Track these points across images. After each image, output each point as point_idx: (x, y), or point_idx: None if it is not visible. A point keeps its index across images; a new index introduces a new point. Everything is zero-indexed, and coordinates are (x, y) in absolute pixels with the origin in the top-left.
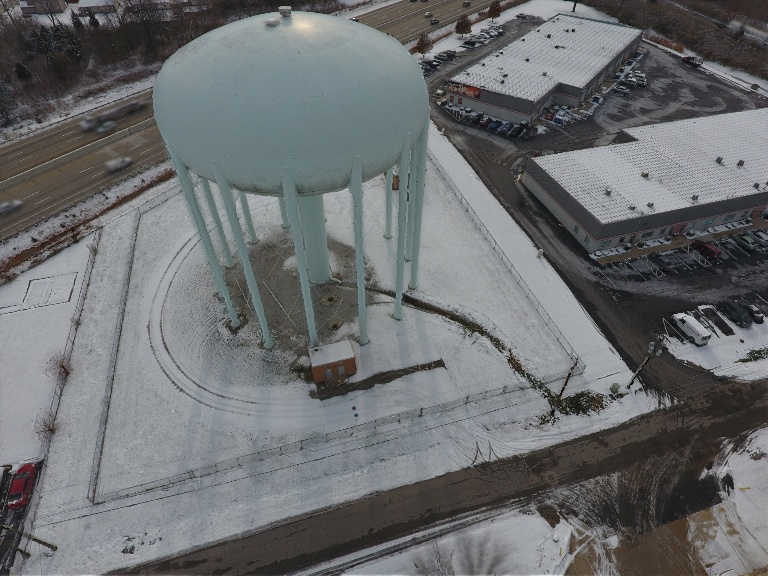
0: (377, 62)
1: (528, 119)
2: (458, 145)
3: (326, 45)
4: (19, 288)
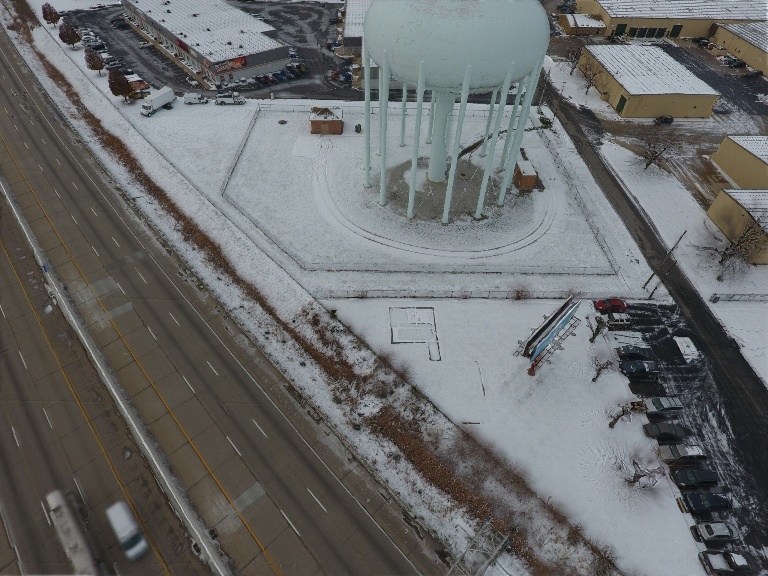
0: None
1: (289, 61)
2: (295, 97)
3: None
4: (403, 350)
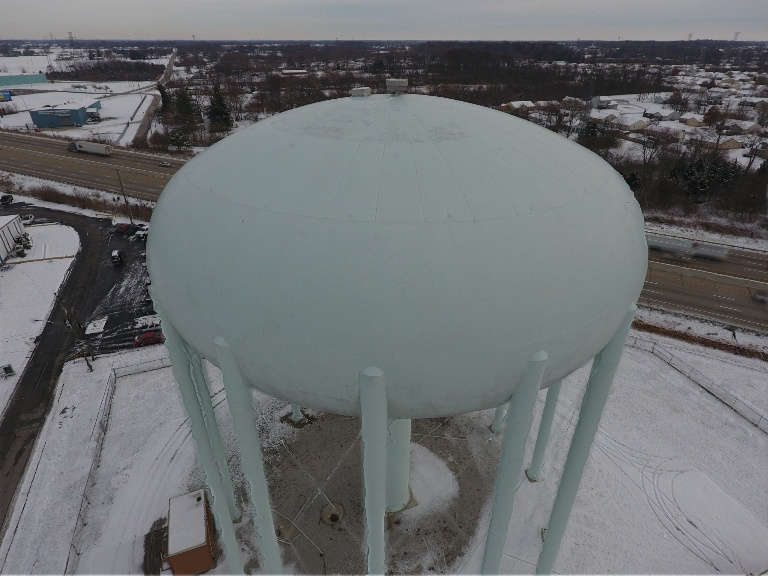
0: (292, 184)
1: None
2: None
3: (300, 128)
4: None
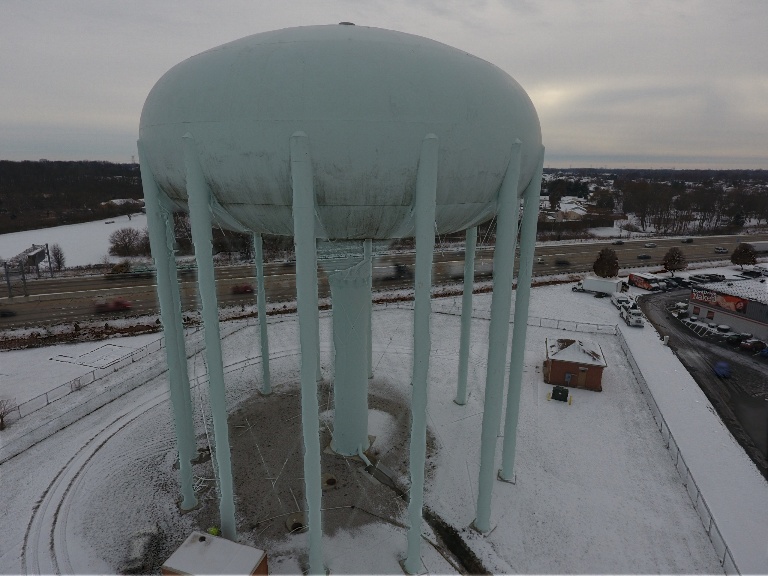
0: (413, 39)
1: None
2: (688, 361)
3: None
4: (93, 346)
